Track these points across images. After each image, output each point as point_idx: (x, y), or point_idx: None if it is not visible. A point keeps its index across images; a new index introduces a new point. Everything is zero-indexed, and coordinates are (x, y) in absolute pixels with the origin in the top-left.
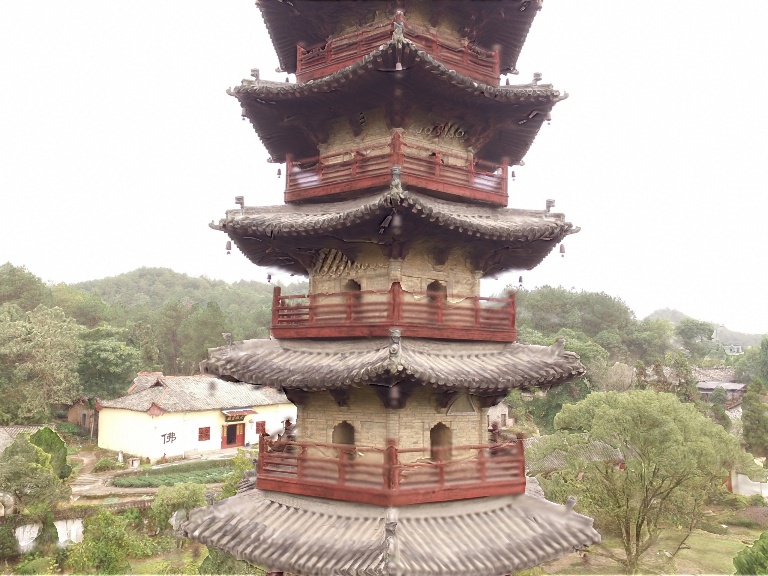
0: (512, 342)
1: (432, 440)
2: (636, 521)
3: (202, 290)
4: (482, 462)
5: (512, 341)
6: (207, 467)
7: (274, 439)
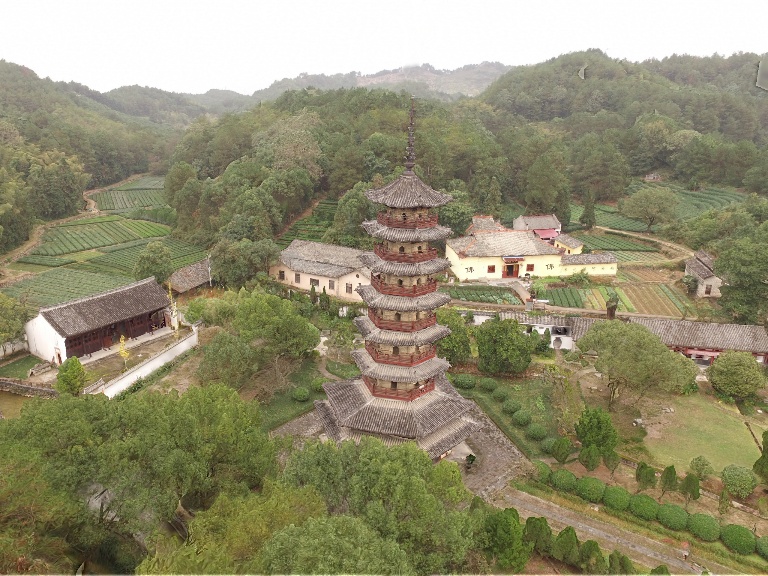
0: (412, 332)
1: (394, 350)
2: None
3: (615, 80)
4: (399, 358)
5: (412, 332)
6: (487, 289)
7: (540, 275)
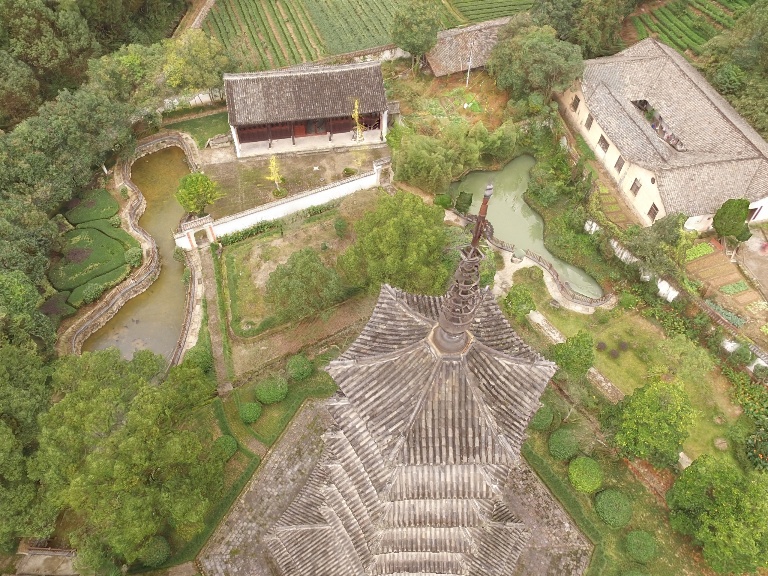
0: None
1: None
2: None
3: None
4: None
5: None
6: None
7: None
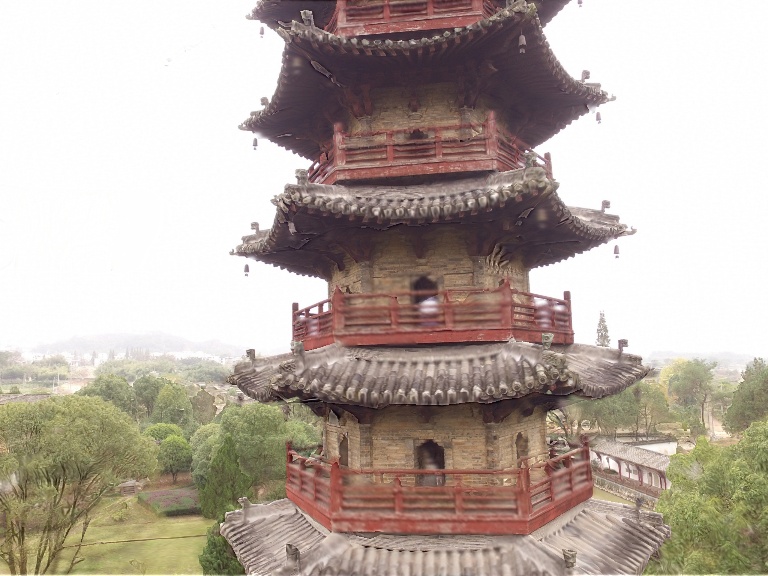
0: None
1: None
2: (38, 550)
3: None
4: None
5: None
6: None
7: None
